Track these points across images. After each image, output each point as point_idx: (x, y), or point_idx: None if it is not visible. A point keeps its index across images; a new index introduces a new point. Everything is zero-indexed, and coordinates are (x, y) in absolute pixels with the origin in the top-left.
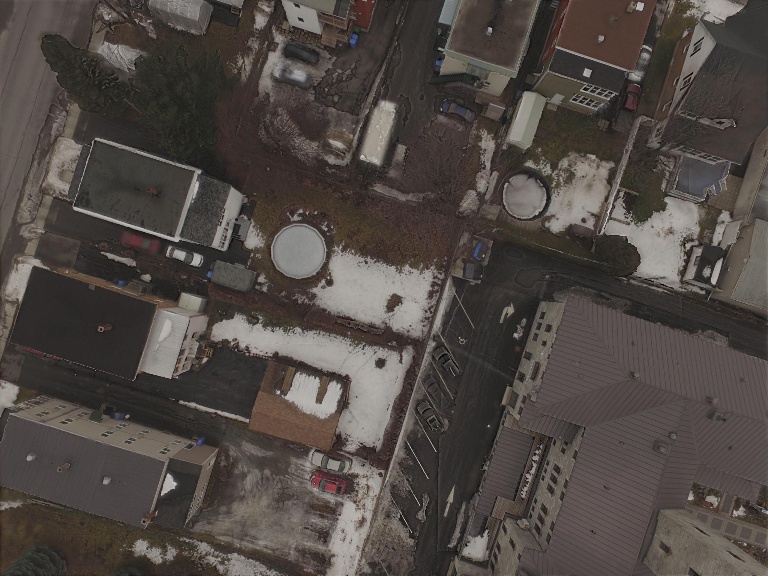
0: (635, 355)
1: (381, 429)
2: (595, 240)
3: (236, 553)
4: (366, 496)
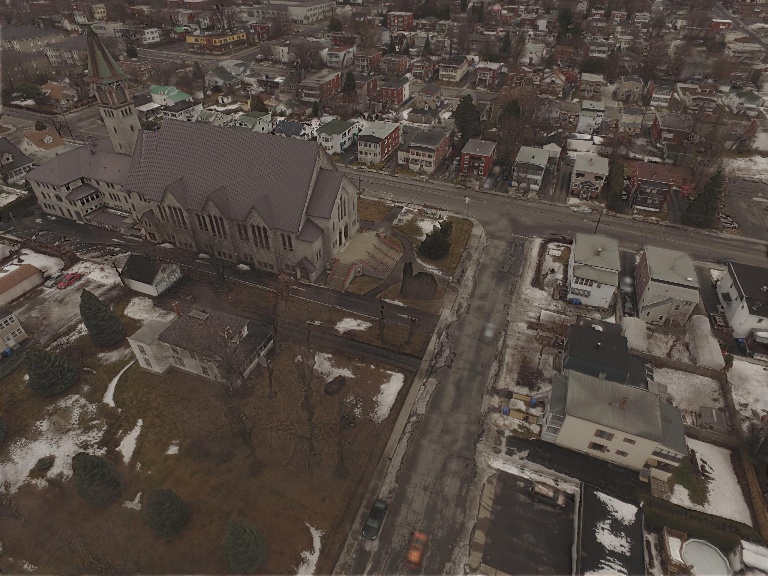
0: None
1: (58, 263)
2: (29, 194)
3: (79, 325)
4: (89, 268)
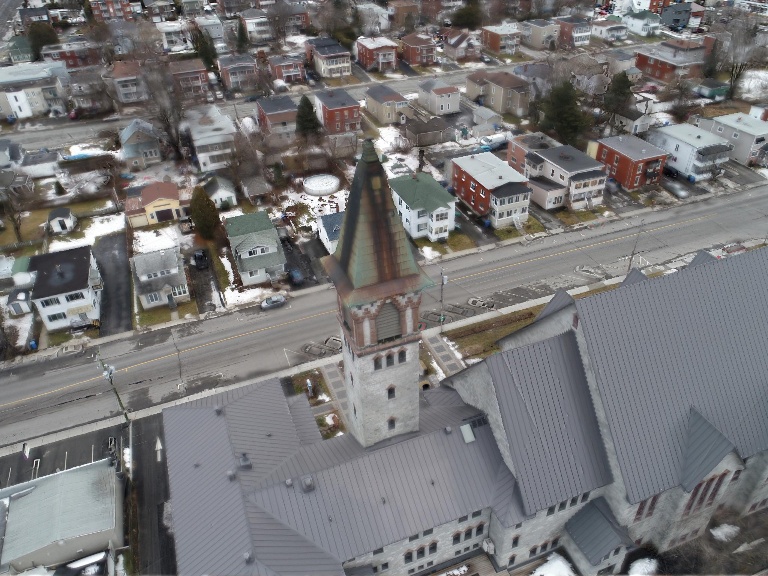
0: (226, 573)
1: None
2: None
3: None
4: None
